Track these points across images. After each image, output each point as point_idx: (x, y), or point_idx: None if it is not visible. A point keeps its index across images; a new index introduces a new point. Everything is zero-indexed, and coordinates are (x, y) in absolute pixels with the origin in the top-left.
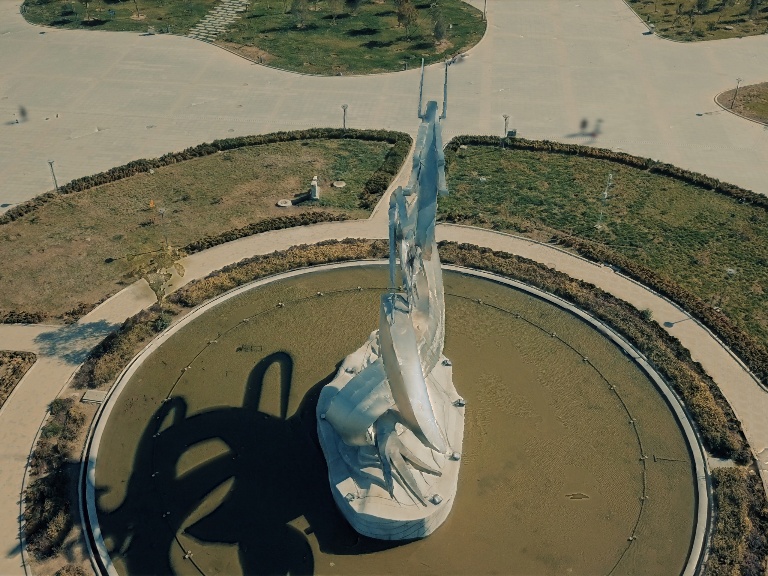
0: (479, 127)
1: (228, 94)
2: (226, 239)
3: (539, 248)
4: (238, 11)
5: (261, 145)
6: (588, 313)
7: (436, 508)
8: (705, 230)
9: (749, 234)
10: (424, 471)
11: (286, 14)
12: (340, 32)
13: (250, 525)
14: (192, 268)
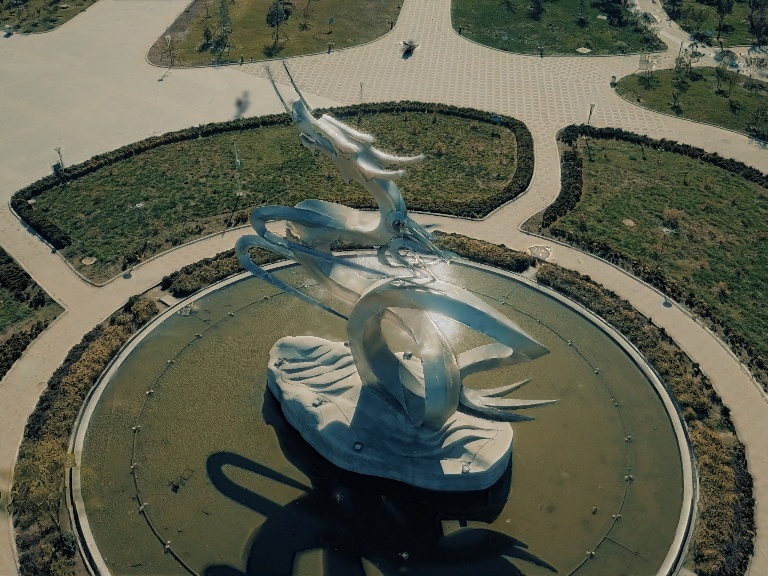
0: (12, 179)
1: None
2: None
3: (232, 235)
4: None
5: None
6: (337, 251)
7: None
8: (300, 154)
9: None
10: None
11: None
12: None
13: (428, 567)
14: None
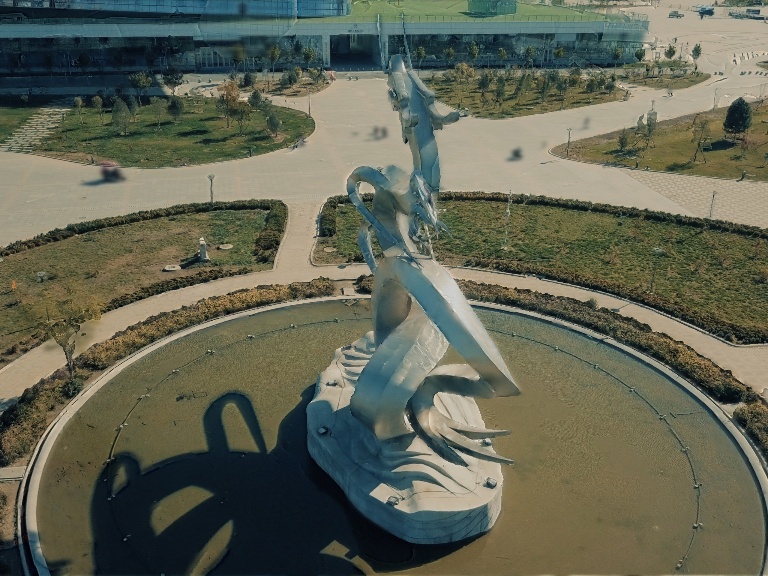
0: None
1: (66, 190)
2: (119, 304)
3: (459, 271)
4: (49, 127)
5: (123, 225)
6: (536, 312)
7: (495, 491)
8: (601, 239)
9: (641, 237)
10: (486, 437)
11: (104, 126)
12: (169, 135)
13: (274, 567)
14: (88, 335)
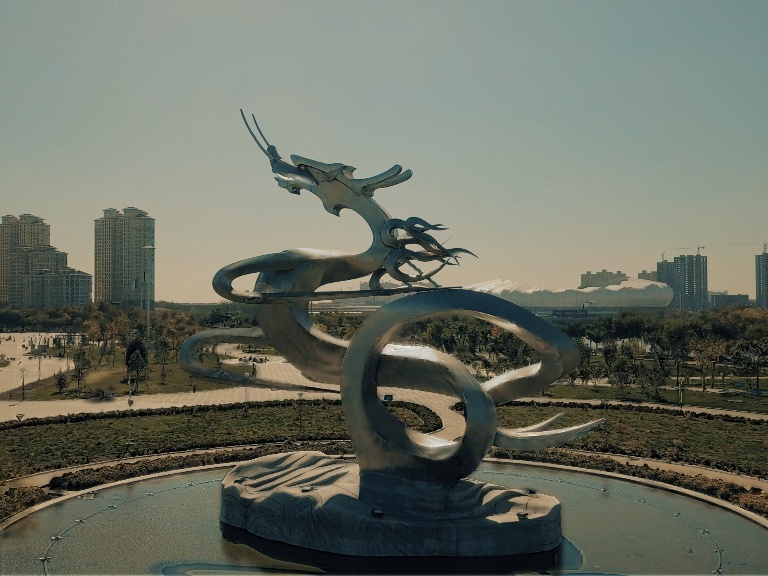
0: None
1: None
2: None
3: (129, 461)
4: None
5: None
6: None
7: None
8: None
9: None
10: None
11: None
12: None
13: None
14: None
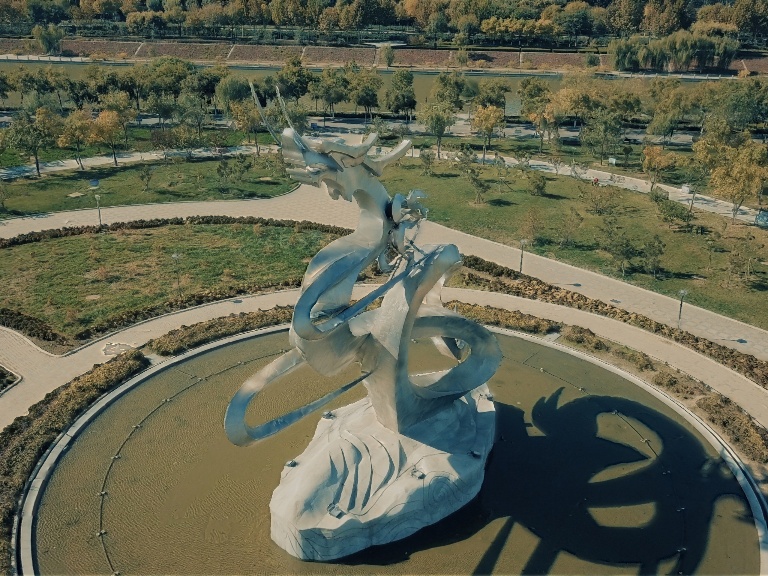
0: None
1: None
2: None
3: None
4: None
5: None
6: (22, 499)
7: (421, 374)
8: None
9: None
10: None
11: None
12: None
13: (582, 449)
14: None
